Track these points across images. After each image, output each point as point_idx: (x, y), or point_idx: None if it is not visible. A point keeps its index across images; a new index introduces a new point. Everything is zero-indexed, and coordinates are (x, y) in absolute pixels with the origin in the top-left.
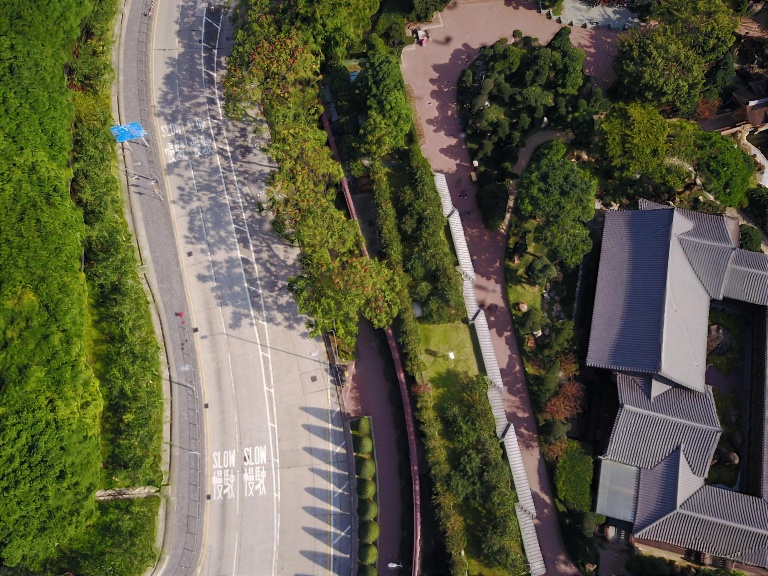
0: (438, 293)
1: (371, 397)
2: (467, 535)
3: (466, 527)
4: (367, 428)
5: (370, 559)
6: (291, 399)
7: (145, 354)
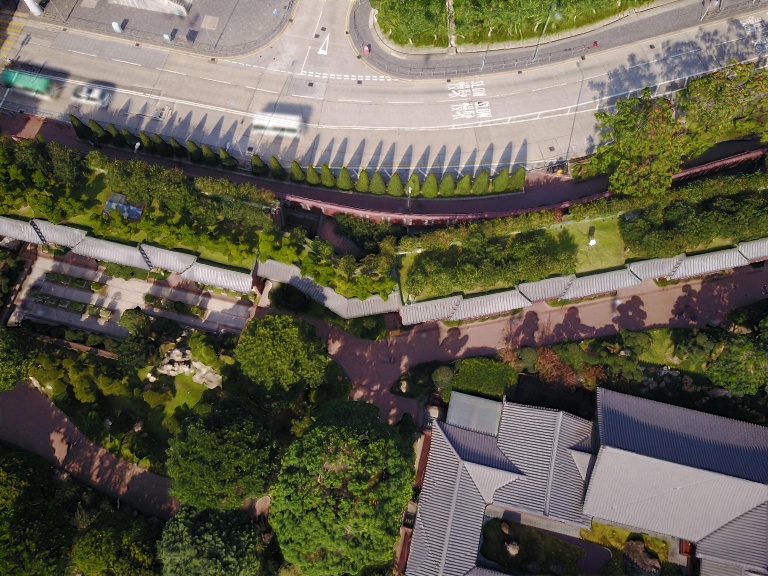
0: (655, 229)
1: (541, 194)
2: (433, 257)
3: (439, 257)
4: (516, 182)
5: (413, 178)
6: (532, 132)
7: (562, 7)
